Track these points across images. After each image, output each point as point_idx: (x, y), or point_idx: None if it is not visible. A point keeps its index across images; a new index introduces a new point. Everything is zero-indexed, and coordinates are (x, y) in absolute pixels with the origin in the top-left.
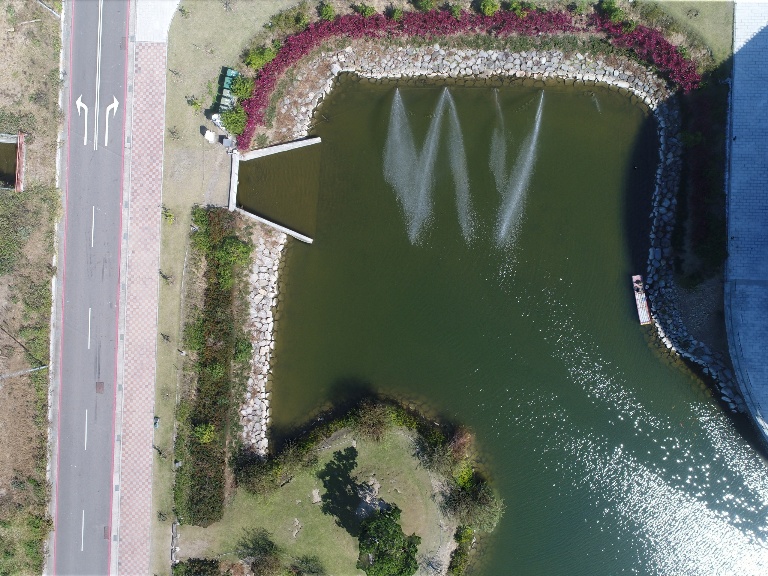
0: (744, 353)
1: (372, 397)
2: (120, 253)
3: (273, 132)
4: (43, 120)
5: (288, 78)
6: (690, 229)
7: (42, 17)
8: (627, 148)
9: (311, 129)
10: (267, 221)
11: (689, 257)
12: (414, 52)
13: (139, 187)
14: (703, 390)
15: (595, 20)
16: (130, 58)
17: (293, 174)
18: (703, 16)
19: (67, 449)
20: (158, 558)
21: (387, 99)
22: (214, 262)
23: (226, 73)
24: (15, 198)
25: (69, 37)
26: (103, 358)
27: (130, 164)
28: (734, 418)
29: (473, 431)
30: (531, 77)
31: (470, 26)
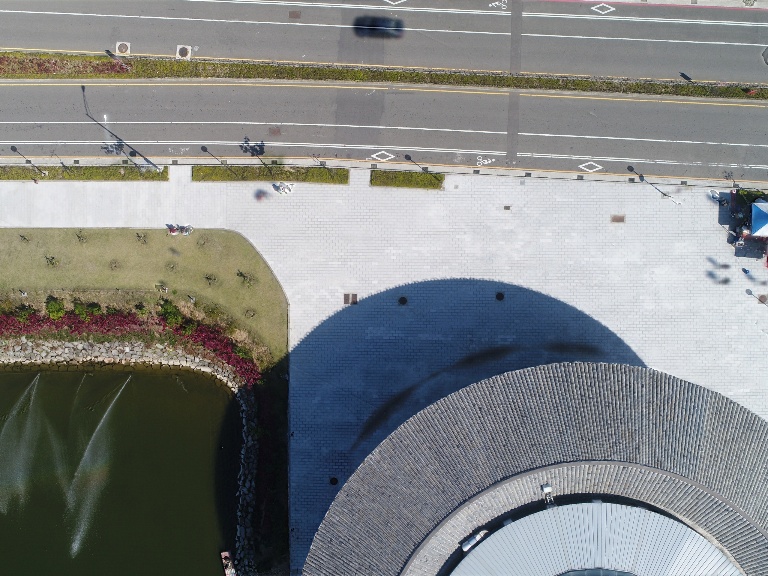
0: None
1: None
2: None
3: None
4: None
5: None
6: None
7: None
8: (215, 427)
9: None
10: None
11: None
12: (4, 343)
13: None
14: None
15: None
16: None
17: None
18: (260, 316)
19: None
20: None
21: None
22: None
23: None
24: None
25: None
26: None
27: None
28: None
29: None
30: (119, 363)
31: None
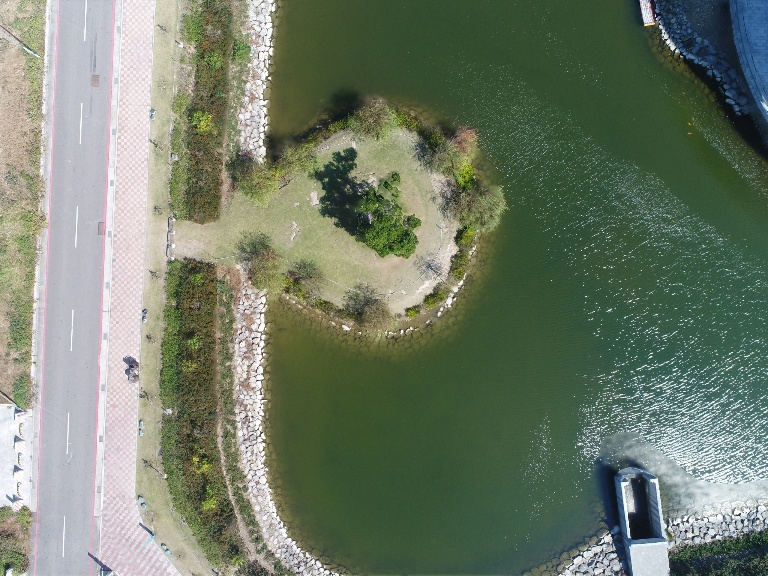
0: (749, 37)
1: None
2: None
3: None
4: None
5: None
6: None
7: None
8: None
9: None
10: None
11: None
12: None
13: None
14: (707, 95)
15: None
16: None
17: None
18: None
19: (61, 144)
20: (153, 254)
21: None
22: None
23: None
24: None
25: None
26: (99, 51)
27: None
28: (738, 122)
29: None
30: None
31: None
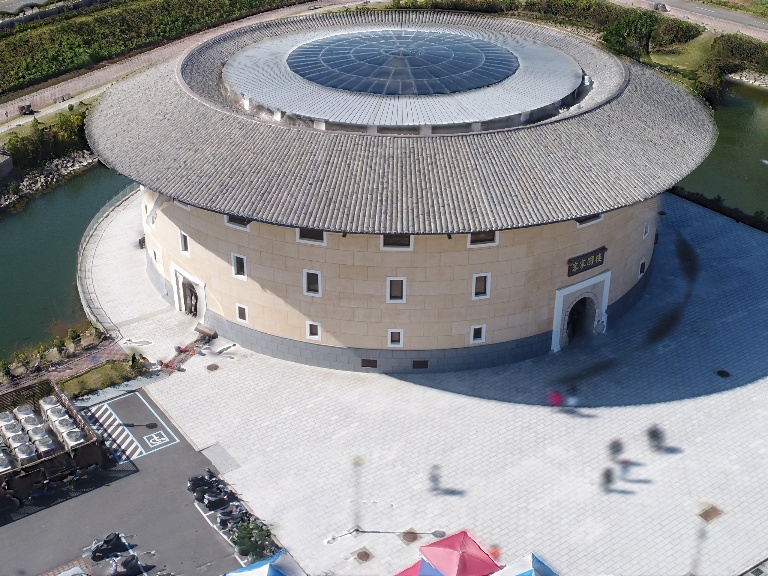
0: None
1: (718, 103)
2: None
3: None
4: None
5: None
6: None
7: None
8: None
9: None
10: None
11: None
12: None
13: None
14: None
15: None
16: None
17: None
18: None
19: None
20: (717, 27)
21: None
22: None
23: None
24: None
25: None
26: None
27: None
28: None
29: None
30: None
31: None
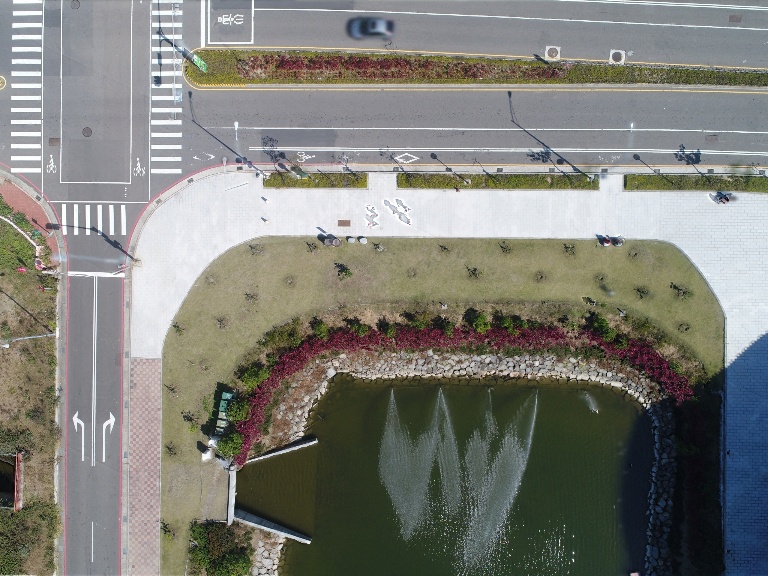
0: None
1: None
2: (120, 568)
3: (269, 438)
4: (40, 436)
5: (283, 386)
6: (686, 533)
7: (37, 334)
8: (622, 444)
9: (307, 429)
10: (266, 528)
11: (686, 561)
12: (408, 357)
13: (137, 502)
14: None
15: (587, 333)
16: (125, 374)
17: (290, 473)
18: (694, 330)
19: None
20: None
21: (382, 402)
22: None
23: (221, 395)
24: (14, 516)
25: (64, 353)
26: None
27: (128, 479)
28: None
29: None
30: (525, 377)
31: (463, 335)
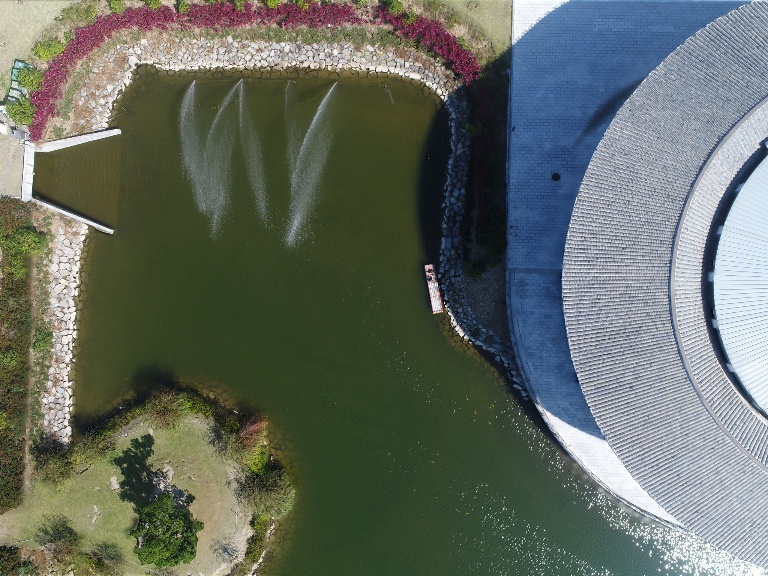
0: (523, 341)
1: (173, 385)
2: None
3: (71, 124)
4: None
5: (84, 70)
6: (476, 218)
7: None
8: (421, 139)
9: (111, 121)
10: (64, 212)
11: (475, 246)
12: (208, 44)
13: None
14: (497, 378)
15: (379, 12)
16: None
17: (95, 165)
18: (483, 8)
19: None
20: None
21: (183, 91)
22: (8, 252)
23: (15, 65)
24: None
25: None
26: None
27: None
28: (527, 406)
29: (272, 419)
30: (325, 69)
31: (260, 18)
